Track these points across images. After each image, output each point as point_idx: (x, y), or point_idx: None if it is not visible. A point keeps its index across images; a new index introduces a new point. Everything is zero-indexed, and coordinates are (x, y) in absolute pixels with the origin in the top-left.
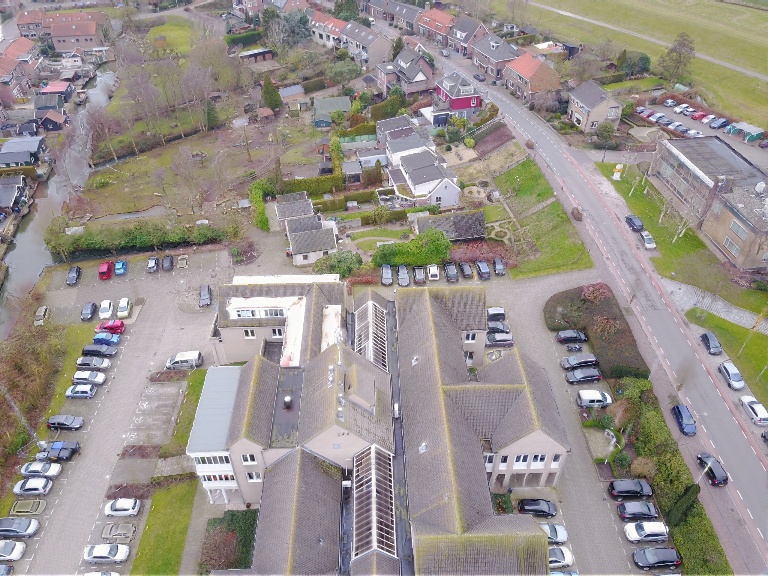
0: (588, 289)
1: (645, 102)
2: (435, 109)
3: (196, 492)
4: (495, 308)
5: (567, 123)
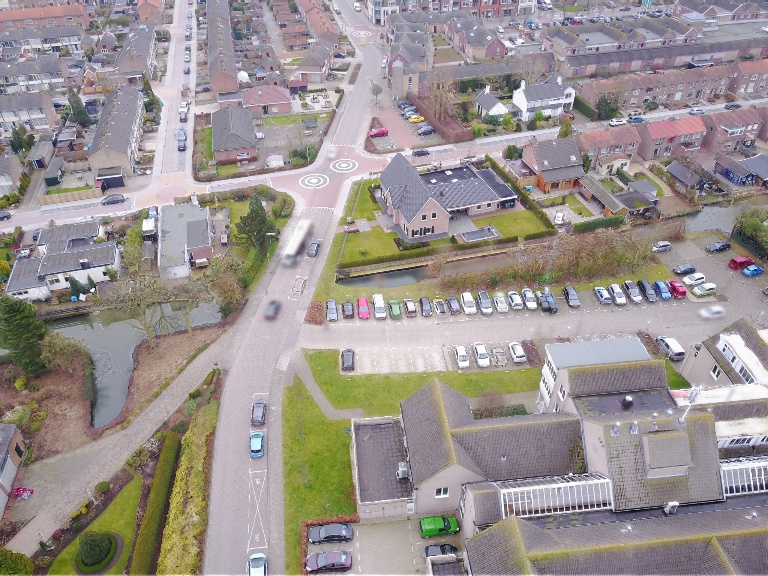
0: None
1: None
2: None
3: None
4: None
5: None
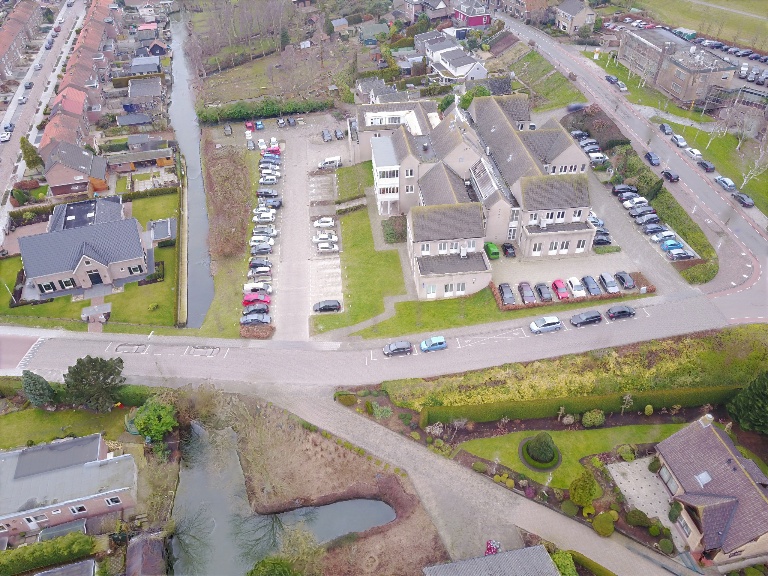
0: (587, 107)
1: (610, 20)
2: (455, 27)
3: (368, 212)
4: None
5: (556, 29)
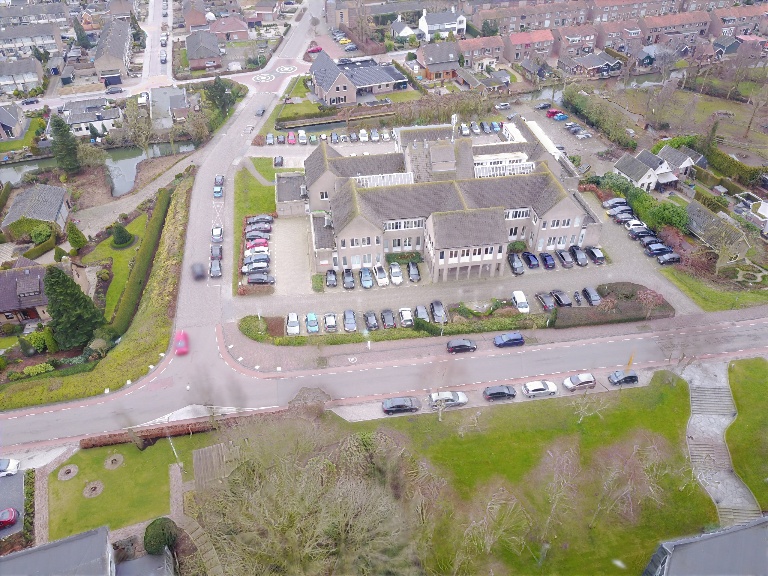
0: None
1: None
2: None
3: None
4: (600, 251)
5: None
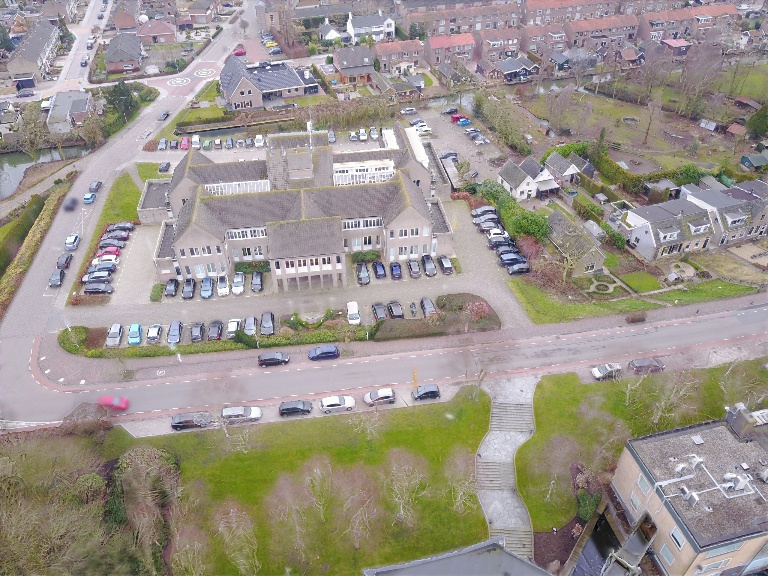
0: None
1: None
2: None
3: None
4: (449, 261)
5: None
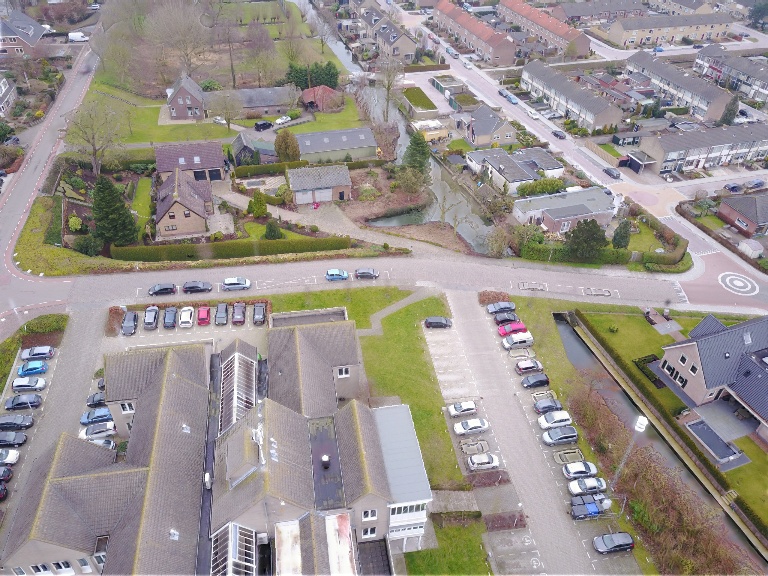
0: None
1: None
2: None
3: None
4: None
5: None
